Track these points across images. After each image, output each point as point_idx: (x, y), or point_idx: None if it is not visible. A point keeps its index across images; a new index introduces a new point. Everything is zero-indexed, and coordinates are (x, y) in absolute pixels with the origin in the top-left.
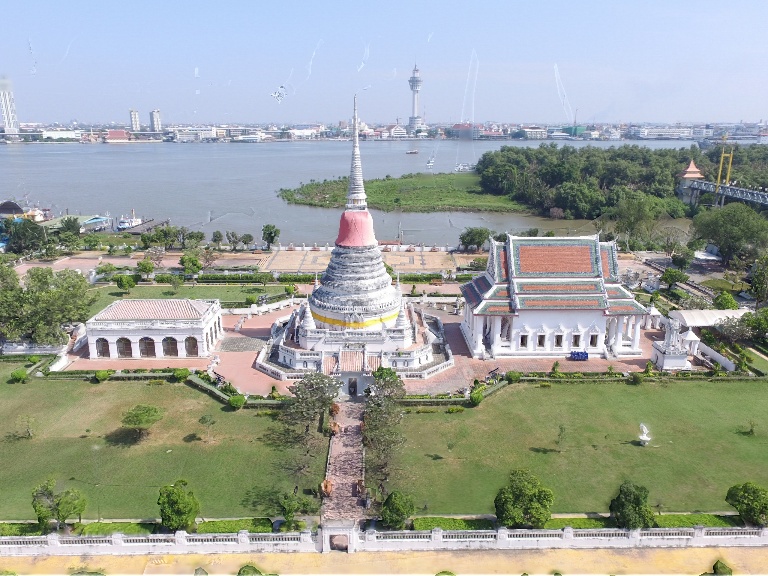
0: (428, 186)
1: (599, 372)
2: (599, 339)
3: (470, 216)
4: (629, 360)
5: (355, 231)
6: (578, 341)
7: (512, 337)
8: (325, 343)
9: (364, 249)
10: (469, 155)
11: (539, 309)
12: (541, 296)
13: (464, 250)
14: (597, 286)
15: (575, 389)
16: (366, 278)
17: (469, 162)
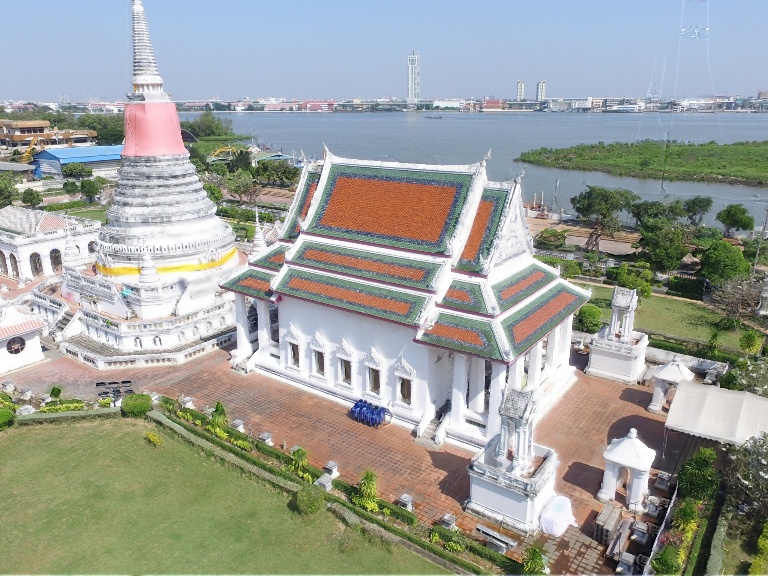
0: (654, 138)
1: (284, 454)
2: (415, 390)
3: (736, 190)
4: (455, 457)
5: (128, 132)
6: (379, 382)
7: (279, 341)
8: (68, 287)
9: (138, 161)
10: (700, 86)
11: (302, 297)
12: (322, 274)
13: (582, 221)
14: (429, 274)
15: (184, 469)
16: (133, 204)
17: (700, 98)
